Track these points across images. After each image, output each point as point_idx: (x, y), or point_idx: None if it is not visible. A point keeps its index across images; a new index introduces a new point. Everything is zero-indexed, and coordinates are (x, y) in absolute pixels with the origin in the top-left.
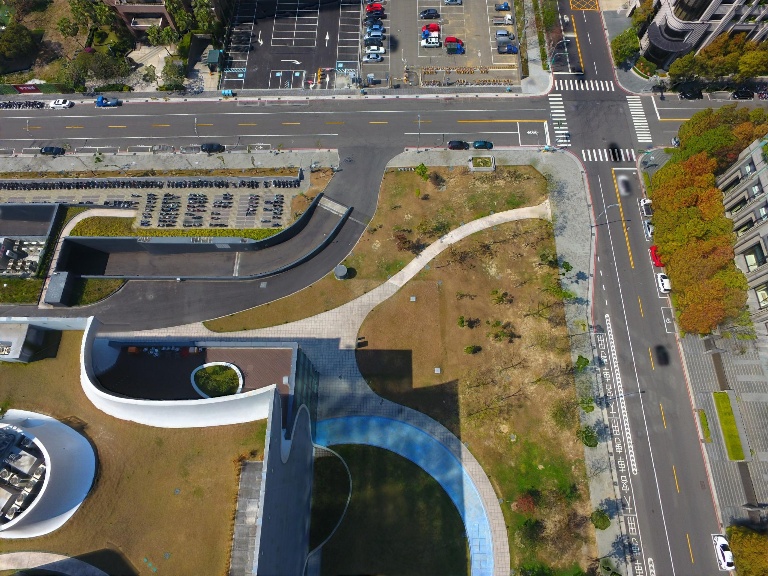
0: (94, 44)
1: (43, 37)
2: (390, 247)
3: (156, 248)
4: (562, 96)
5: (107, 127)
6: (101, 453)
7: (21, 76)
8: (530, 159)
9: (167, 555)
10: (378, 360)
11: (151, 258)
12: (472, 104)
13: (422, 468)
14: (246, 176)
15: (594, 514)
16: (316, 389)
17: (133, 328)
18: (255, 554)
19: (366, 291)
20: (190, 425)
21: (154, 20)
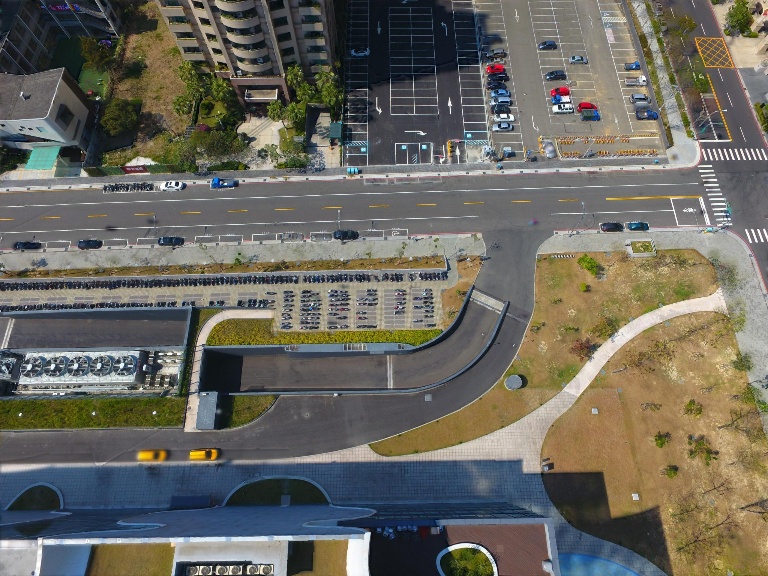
0: (201, 117)
1: (142, 108)
2: (559, 349)
3: (302, 355)
4: (713, 167)
5: (226, 212)
6: None
7: (124, 154)
8: (692, 242)
9: None
10: (568, 485)
11: (292, 362)
12: (618, 178)
13: None
14: (390, 269)
15: None
16: None
17: (293, 453)
18: None
19: (542, 403)
20: None
21: (269, 92)
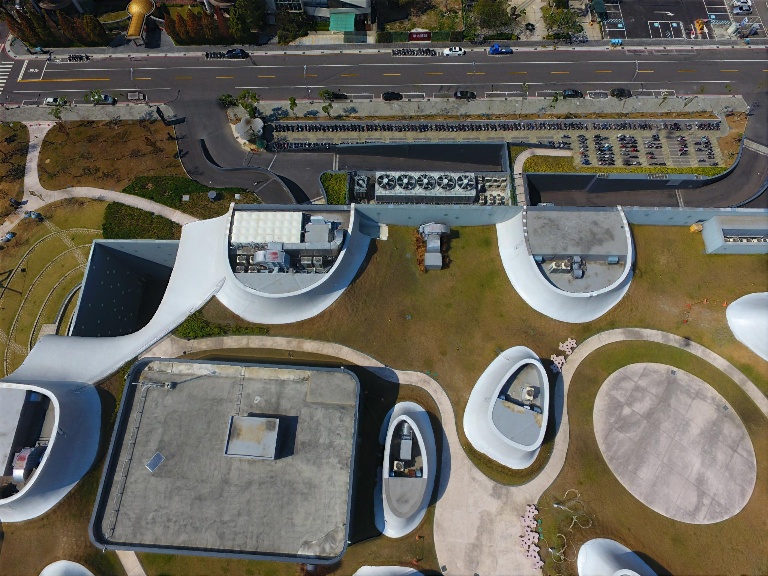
0: None
1: None
2: None
3: (605, 185)
4: None
5: (508, 73)
6: None
7: (402, 25)
8: None
9: None
10: None
11: (587, 196)
12: None
13: None
14: (670, 118)
15: None
16: None
17: None
18: None
19: None
20: None
21: None
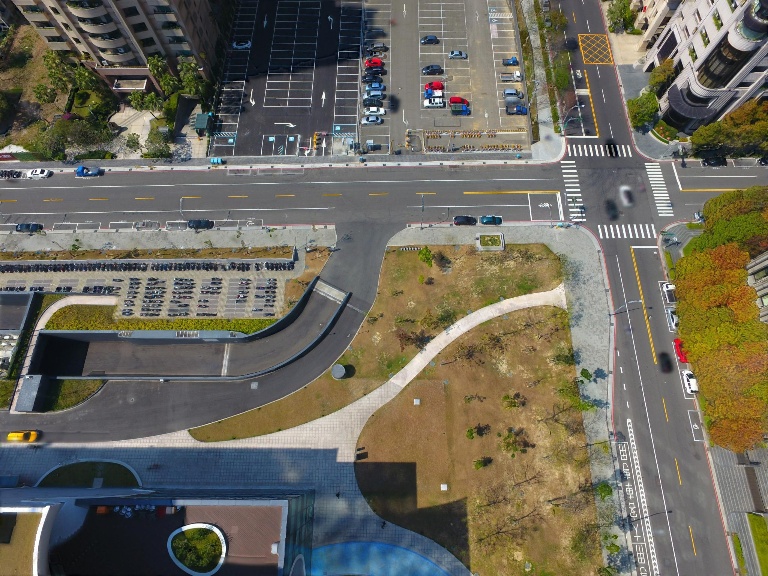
0: (75, 106)
1: (21, 97)
2: (392, 340)
3: (139, 341)
4: (576, 163)
5: (88, 200)
6: None
7: None
8: (542, 236)
9: None
10: (379, 475)
11: (134, 349)
12: (479, 173)
13: None
14: (236, 258)
15: None
16: (311, 510)
17: (112, 437)
18: None
19: (366, 393)
20: None
21: (138, 82)
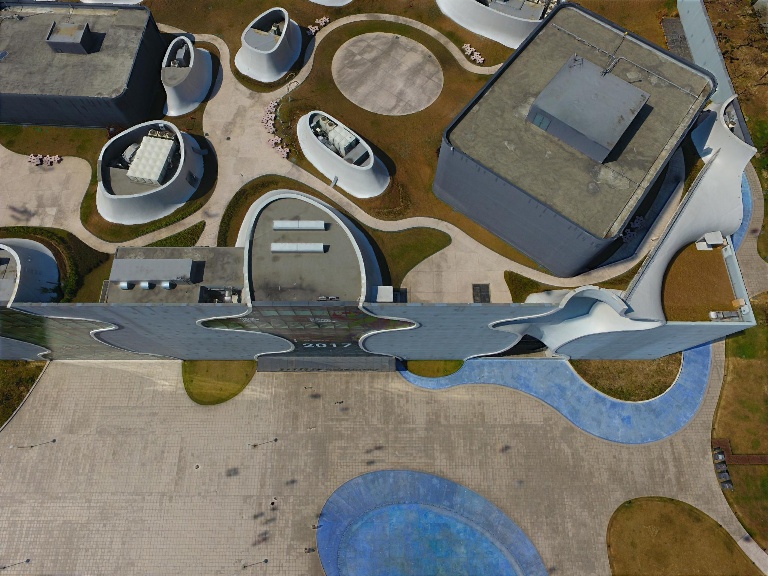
0: None
1: None
2: None
3: None
4: None
5: None
6: None
7: None
8: None
9: None
10: None
11: None
12: None
13: None
14: None
15: None
16: None
17: None
18: (711, 31)
19: None
20: None
21: None
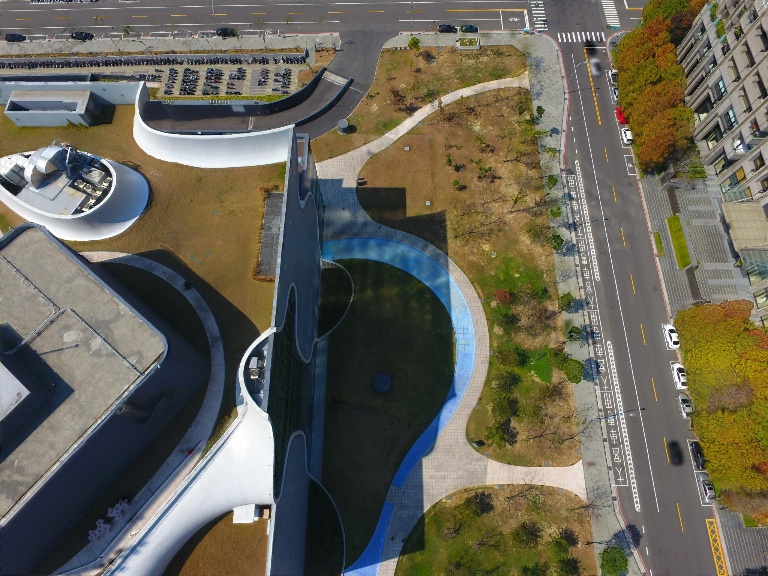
0: None
1: None
2: (386, 109)
3: (178, 112)
4: None
5: (131, 17)
6: (153, 184)
7: None
8: (511, 40)
9: (209, 253)
10: (376, 195)
11: (173, 124)
12: None
13: (415, 276)
14: (257, 53)
15: (560, 298)
16: (322, 217)
17: None
18: (281, 230)
19: (365, 143)
20: (224, 166)
21: None
